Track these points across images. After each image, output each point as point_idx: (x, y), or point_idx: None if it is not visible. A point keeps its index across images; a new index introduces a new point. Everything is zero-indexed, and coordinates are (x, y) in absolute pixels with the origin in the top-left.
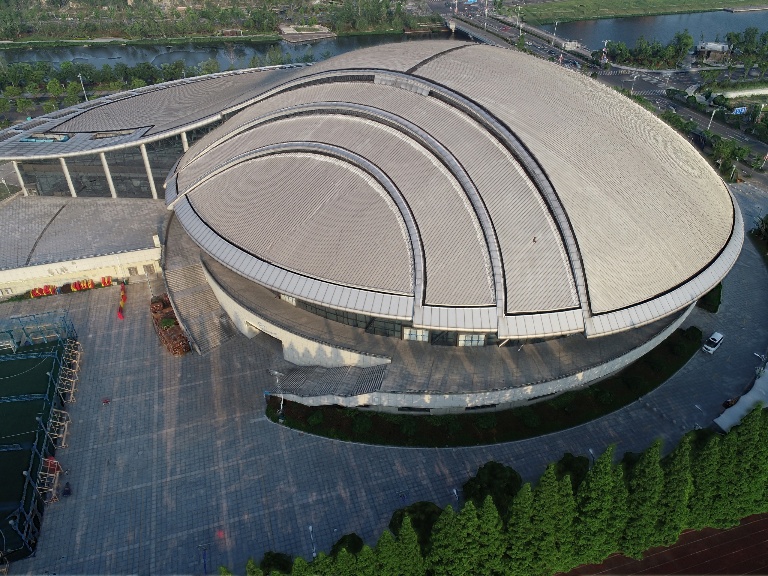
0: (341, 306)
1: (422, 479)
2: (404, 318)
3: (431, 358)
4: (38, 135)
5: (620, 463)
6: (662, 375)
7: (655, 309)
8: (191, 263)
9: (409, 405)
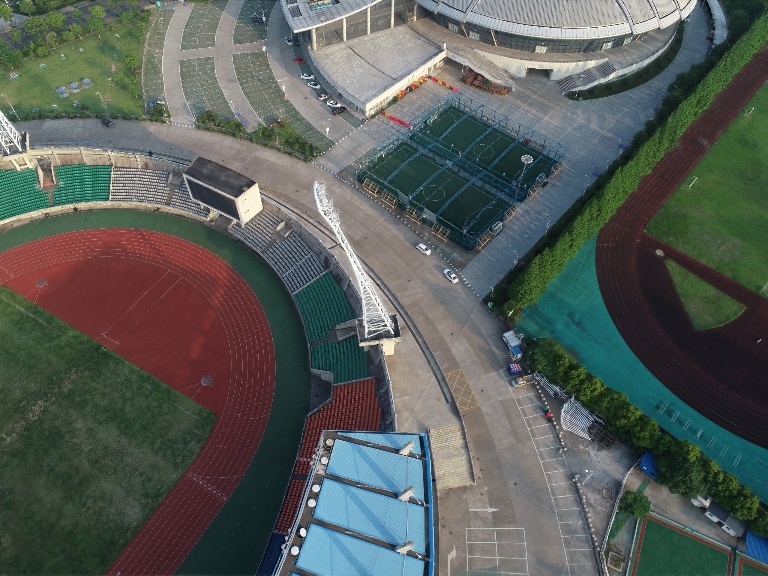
0: (604, 36)
1: (644, 97)
2: (628, 32)
3: (619, 53)
4: (313, 4)
5: (706, 63)
6: (682, 35)
7: (693, 3)
8: (471, 52)
9: (627, 72)
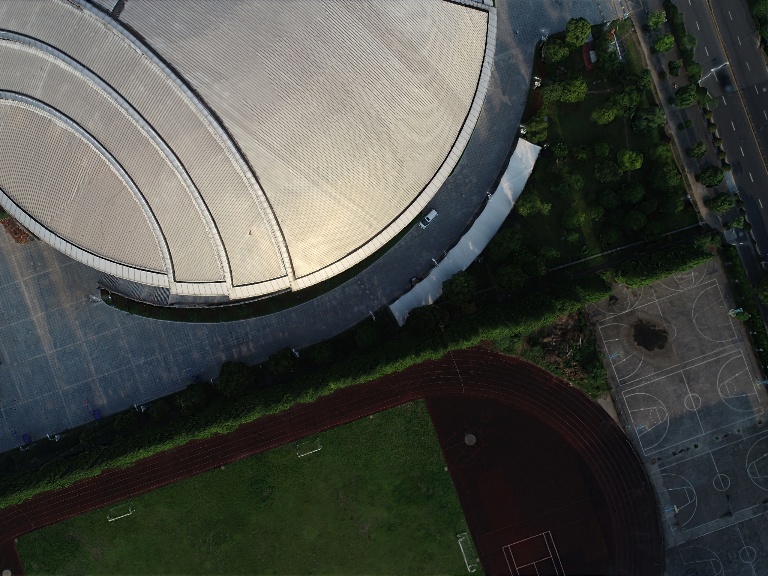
0: (119, 276)
1: (205, 346)
2: None
3: None
4: None
5: None
6: None
7: (347, 263)
8: None
9: None
